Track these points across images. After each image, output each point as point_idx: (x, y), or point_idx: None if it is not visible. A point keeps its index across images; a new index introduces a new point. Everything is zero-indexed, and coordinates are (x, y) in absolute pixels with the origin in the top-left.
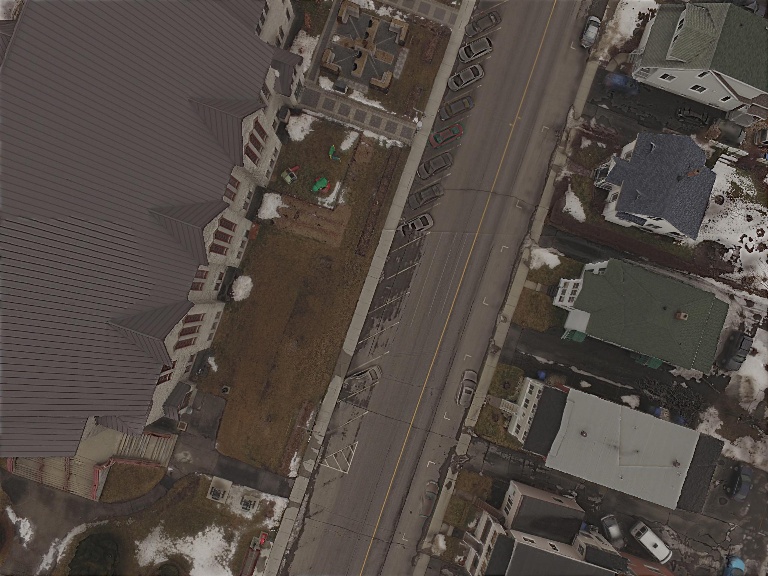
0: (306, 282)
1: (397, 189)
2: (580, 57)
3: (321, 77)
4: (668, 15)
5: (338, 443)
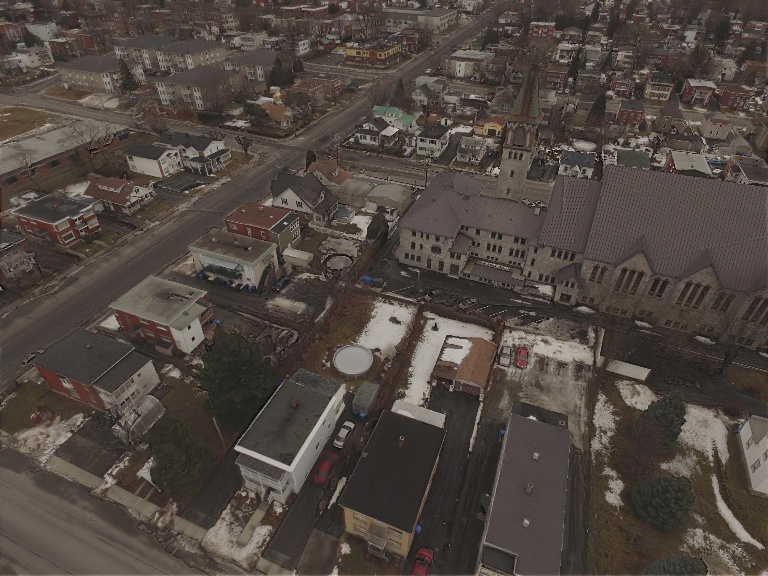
0: None
1: None
2: None
3: None
4: None
5: None
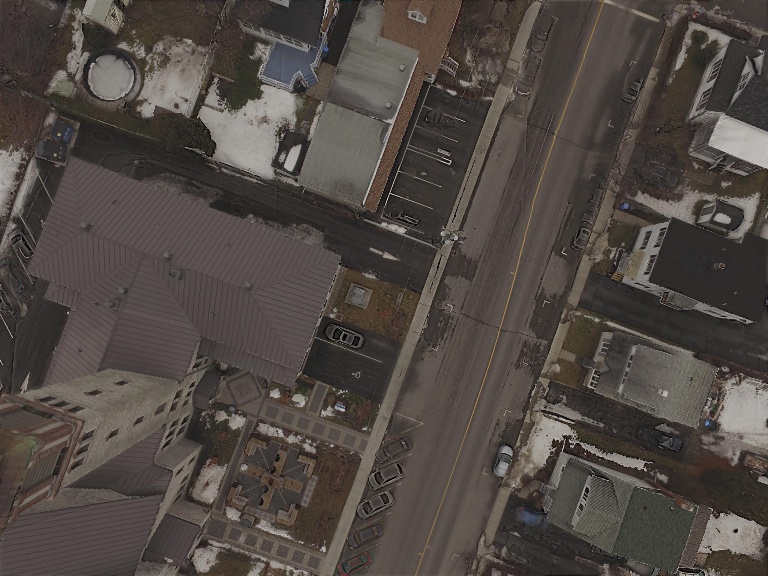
0: None
1: None
2: (492, 483)
3: (228, 507)
4: (576, 473)
5: None
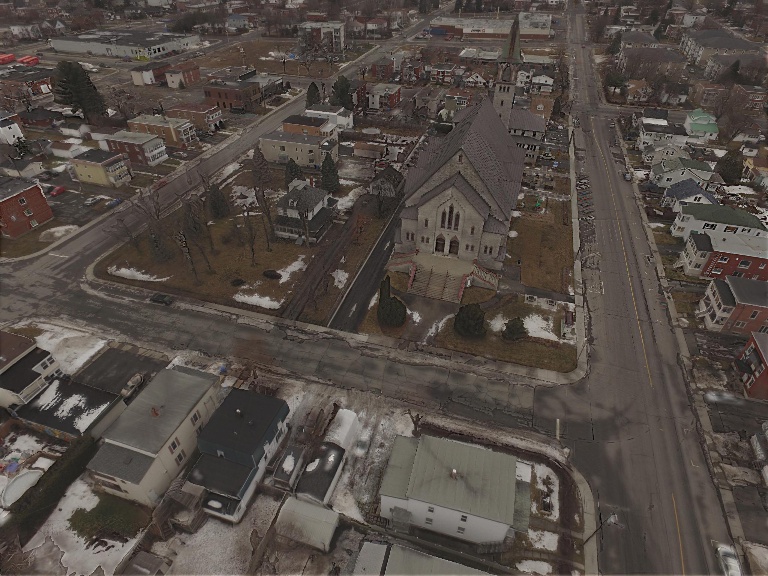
0: (544, 232)
1: (572, 210)
2: None
3: None
4: None
5: None
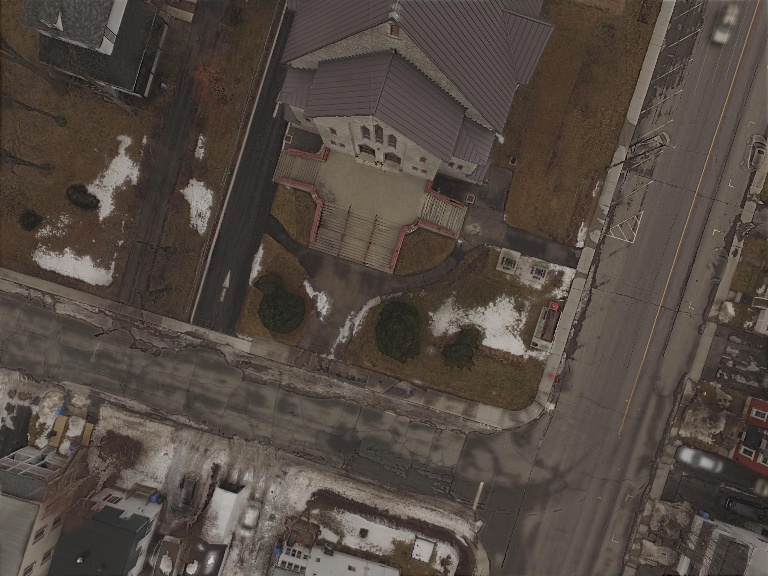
0: (589, 51)
1: None
2: None
3: None
4: None
5: (623, 213)
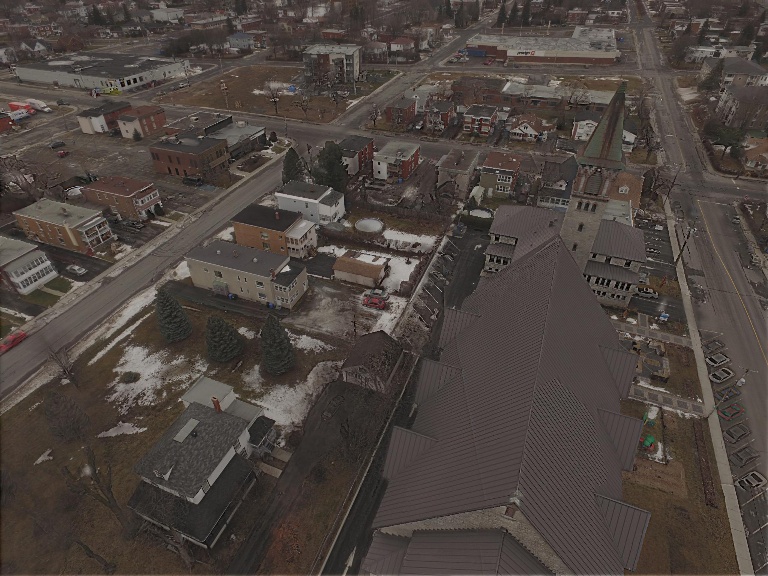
0: (671, 532)
1: (714, 450)
2: None
3: None
4: None
5: None
